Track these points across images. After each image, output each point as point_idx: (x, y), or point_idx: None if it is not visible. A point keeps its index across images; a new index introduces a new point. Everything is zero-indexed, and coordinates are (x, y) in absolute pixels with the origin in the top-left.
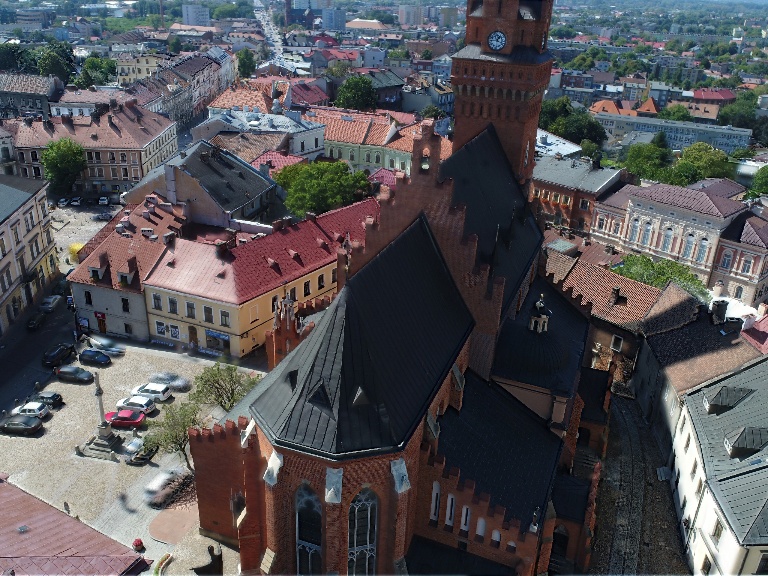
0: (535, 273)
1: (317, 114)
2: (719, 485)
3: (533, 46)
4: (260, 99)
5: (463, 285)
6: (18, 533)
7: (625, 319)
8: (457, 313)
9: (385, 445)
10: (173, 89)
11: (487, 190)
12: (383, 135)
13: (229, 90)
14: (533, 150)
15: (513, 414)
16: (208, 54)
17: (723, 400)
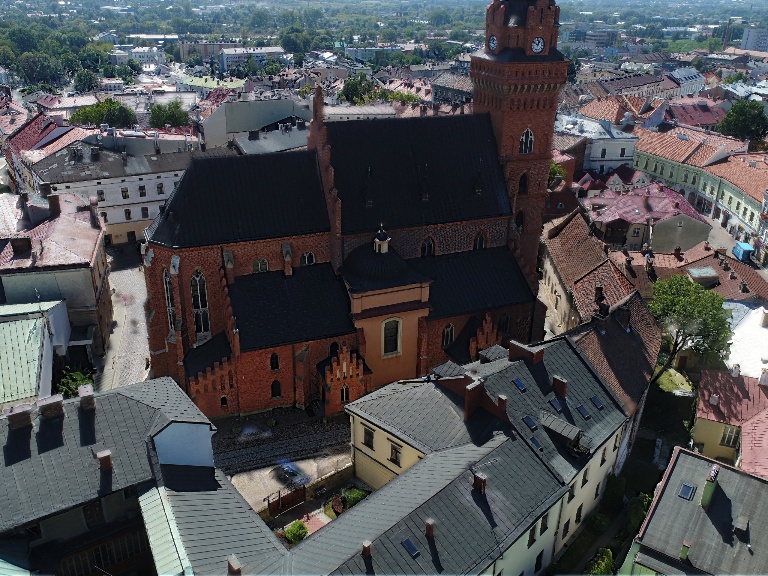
0: (502, 243)
1: (679, 132)
2: (394, 384)
3: (523, 49)
4: (615, 110)
5: (327, 201)
6: (69, 239)
7: (589, 314)
8: (314, 217)
9: (170, 244)
10: (582, 99)
11: (426, 154)
12: (707, 157)
13: (596, 100)
14: (548, 143)
15: (336, 300)
16: (671, 74)
17: (489, 353)
